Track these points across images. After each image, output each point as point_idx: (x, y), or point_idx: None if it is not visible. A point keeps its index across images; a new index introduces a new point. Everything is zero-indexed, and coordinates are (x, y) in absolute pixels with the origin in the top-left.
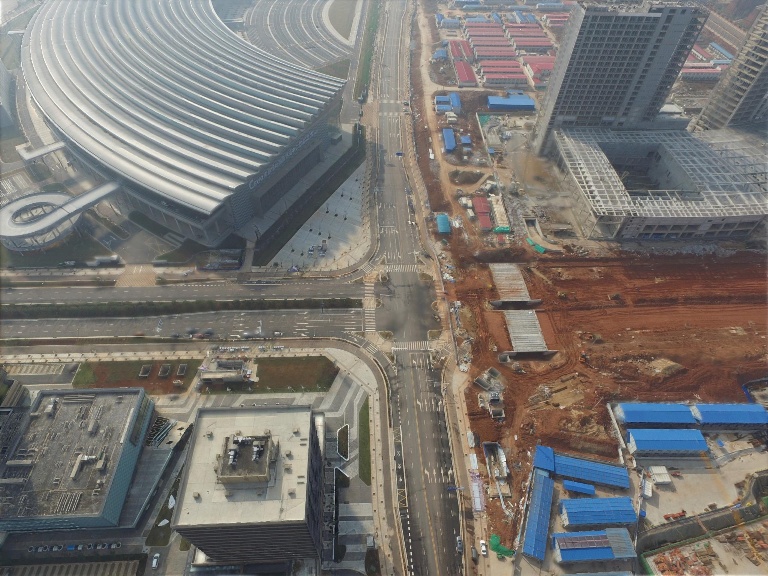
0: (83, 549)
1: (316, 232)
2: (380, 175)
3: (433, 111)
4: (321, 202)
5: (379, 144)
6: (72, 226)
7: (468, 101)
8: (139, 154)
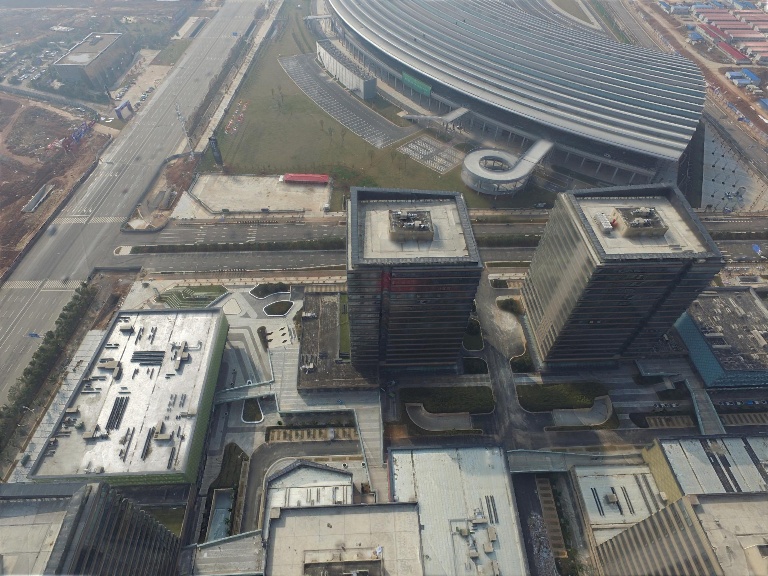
0: (760, 404)
1: (719, 182)
2: (729, 137)
3: (732, 84)
4: (701, 158)
5: (704, 112)
6: (530, 175)
7: (758, 76)
8: (573, 114)
